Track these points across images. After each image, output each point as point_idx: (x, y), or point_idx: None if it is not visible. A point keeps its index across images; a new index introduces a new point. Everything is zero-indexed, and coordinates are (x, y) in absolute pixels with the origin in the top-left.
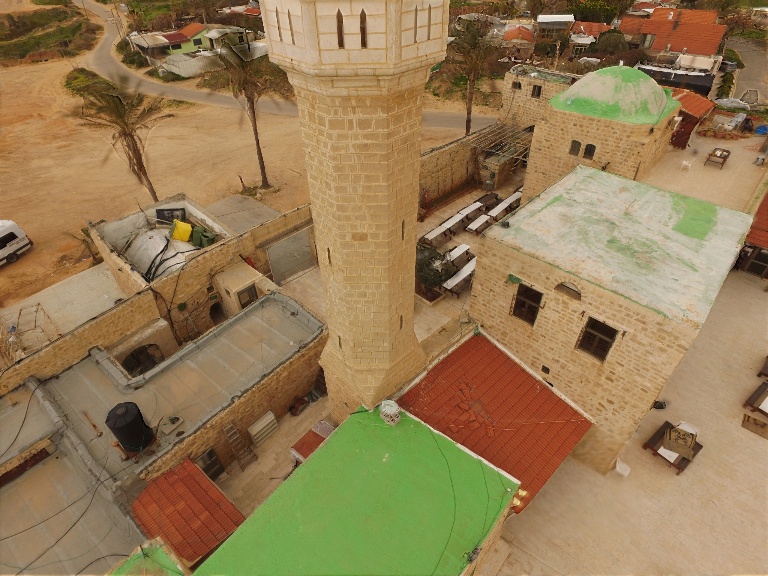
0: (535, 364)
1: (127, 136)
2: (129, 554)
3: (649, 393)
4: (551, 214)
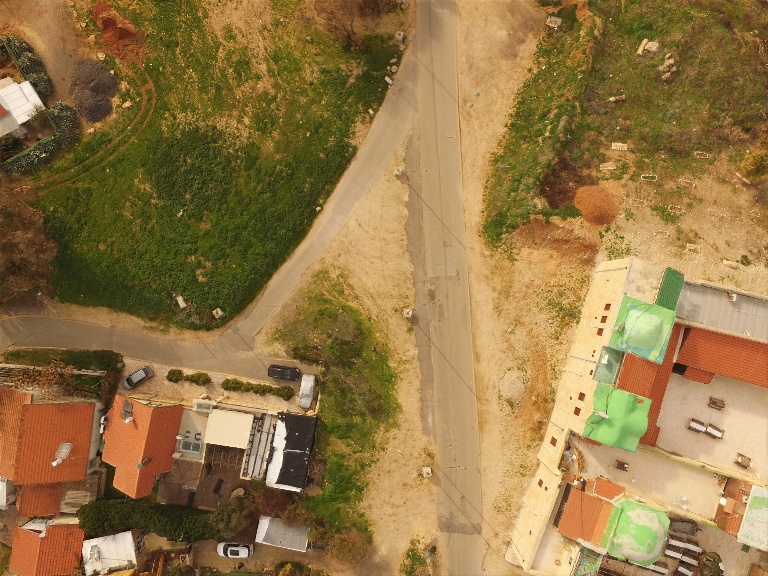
0: None
1: None
2: None
3: None
4: None
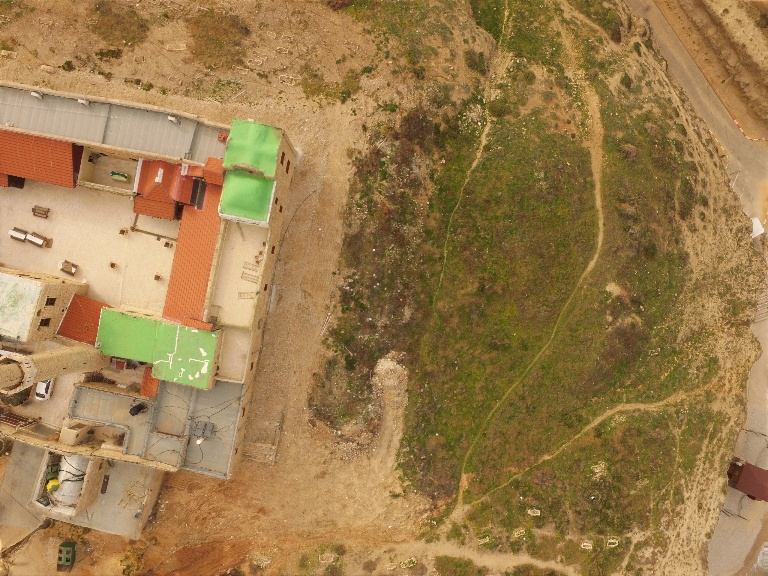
0: (62, 314)
1: (4, 554)
2: (165, 388)
3: (61, 285)
4: (5, 326)
